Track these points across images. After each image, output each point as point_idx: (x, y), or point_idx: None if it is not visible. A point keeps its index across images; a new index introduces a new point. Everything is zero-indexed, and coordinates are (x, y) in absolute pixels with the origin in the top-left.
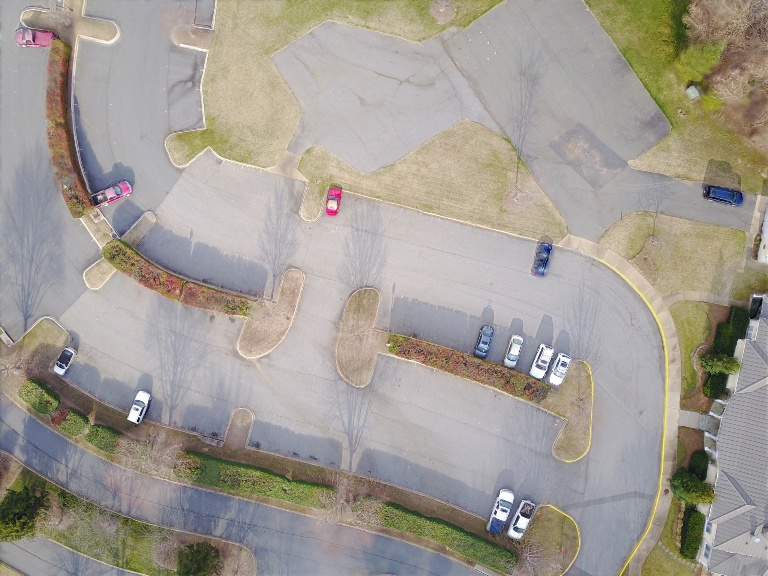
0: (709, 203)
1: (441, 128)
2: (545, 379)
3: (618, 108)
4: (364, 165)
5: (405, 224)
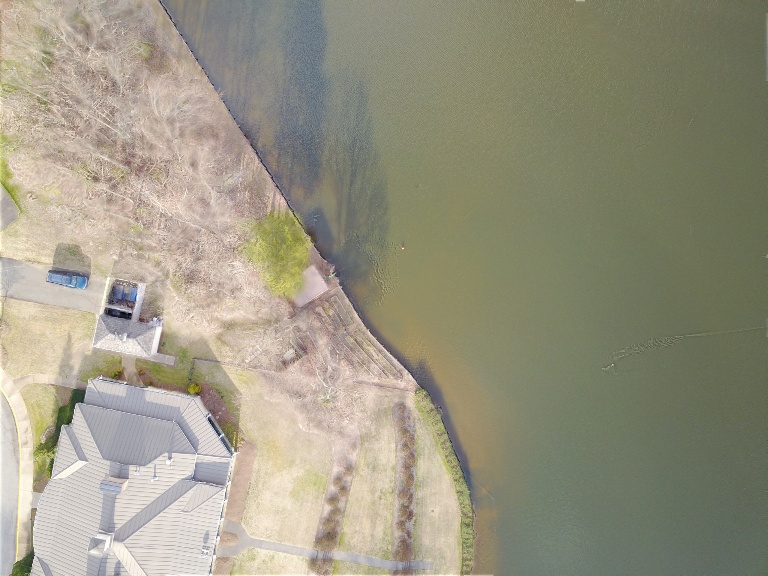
0: (59, 286)
1: None
2: None
3: None
4: None
5: None
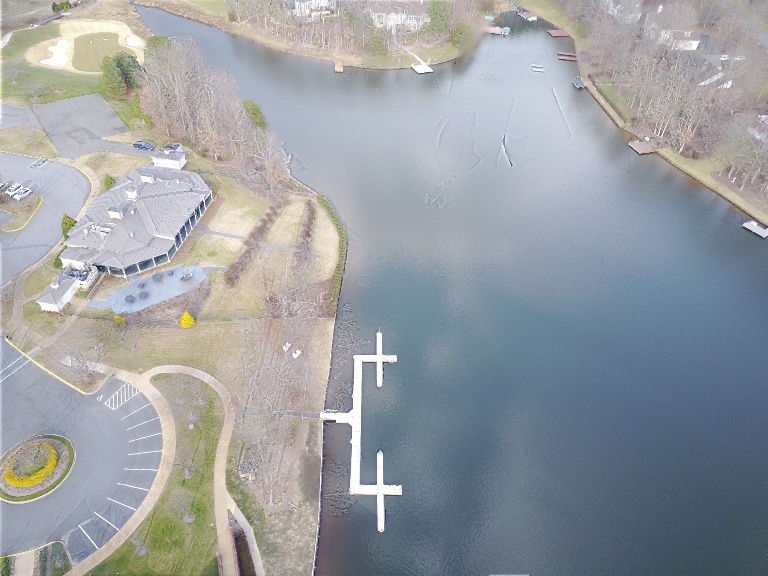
0: (138, 150)
1: None
2: None
3: (105, 124)
4: None
5: None
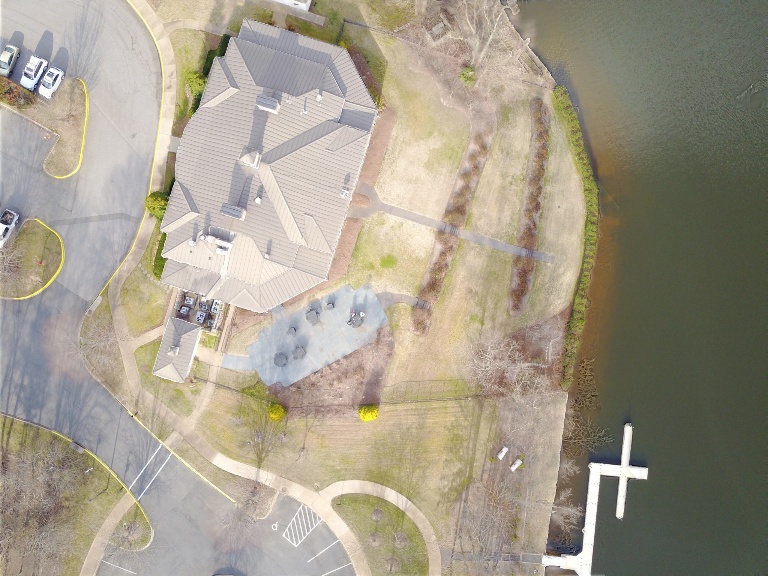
0: None
1: None
2: (38, 92)
3: None
4: None
5: None
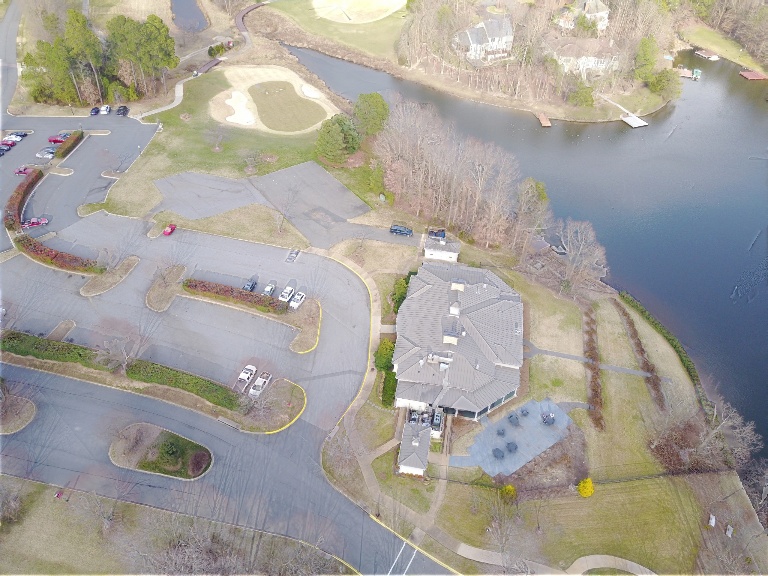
0: (395, 236)
1: (241, 205)
2: (288, 307)
3: (342, 202)
4: (192, 217)
5: (211, 241)
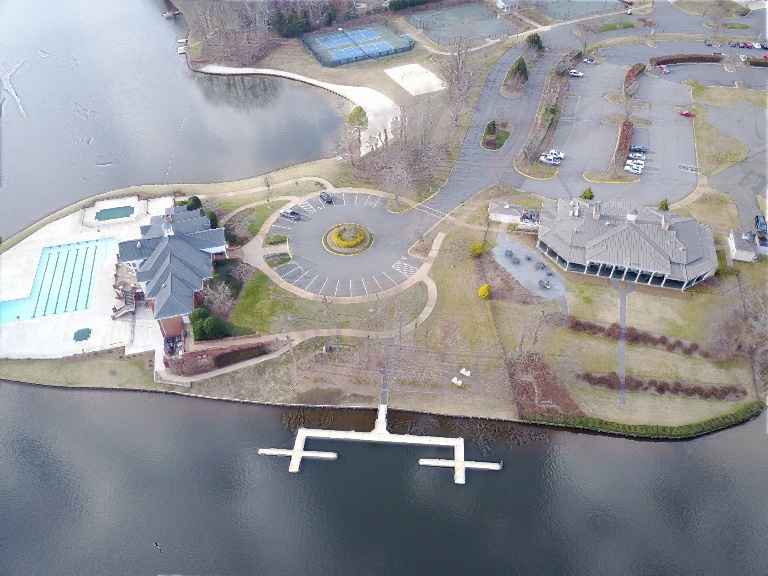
0: None
1: (740, 140)
2: None
3: None
4: None
5: (686, 132)
